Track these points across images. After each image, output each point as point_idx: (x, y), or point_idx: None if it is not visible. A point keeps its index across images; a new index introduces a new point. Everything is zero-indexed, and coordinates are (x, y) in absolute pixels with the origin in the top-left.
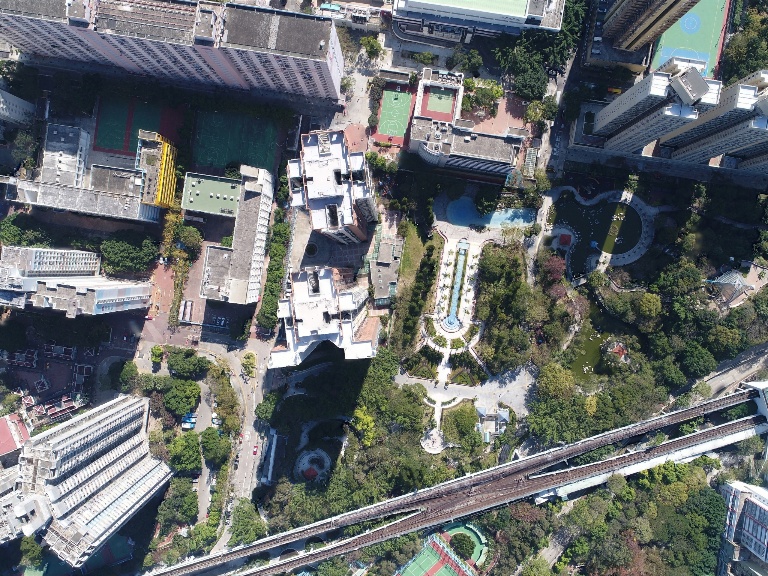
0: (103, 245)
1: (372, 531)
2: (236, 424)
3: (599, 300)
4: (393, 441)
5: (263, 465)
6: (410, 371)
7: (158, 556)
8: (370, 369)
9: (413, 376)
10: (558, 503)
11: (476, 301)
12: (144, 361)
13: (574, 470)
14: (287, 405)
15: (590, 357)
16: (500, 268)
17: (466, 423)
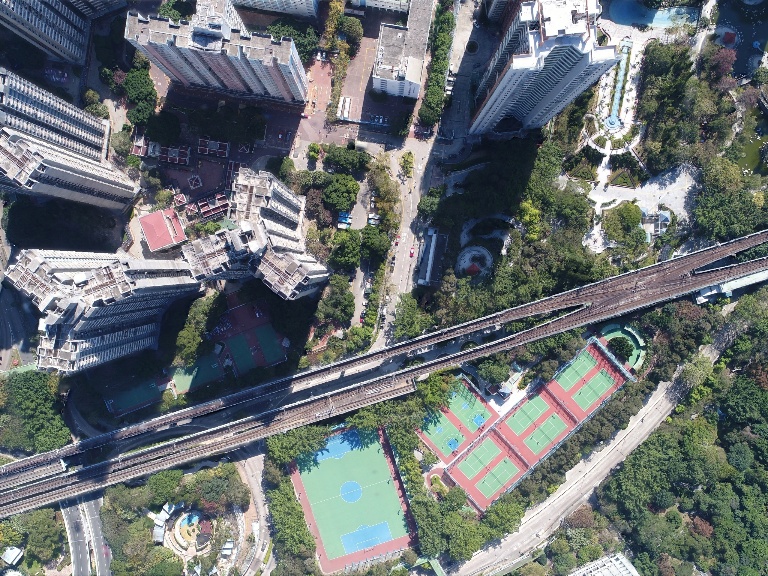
0: (266, 31)
1: (537, 326)
2: (396, 222)
3: (761, 101)
4: (558, 236)
5: (419, 268)
6: (570, 172)
7: (313, 358)
8: (537, 162)
9: (573, 177)
10: (720, 301)
11: (638, 101)
12: (299, 161)
13: (739, 266)
14: (451, 199)
15: (750, 160)
16: (671, 58)
17: (632, 217)
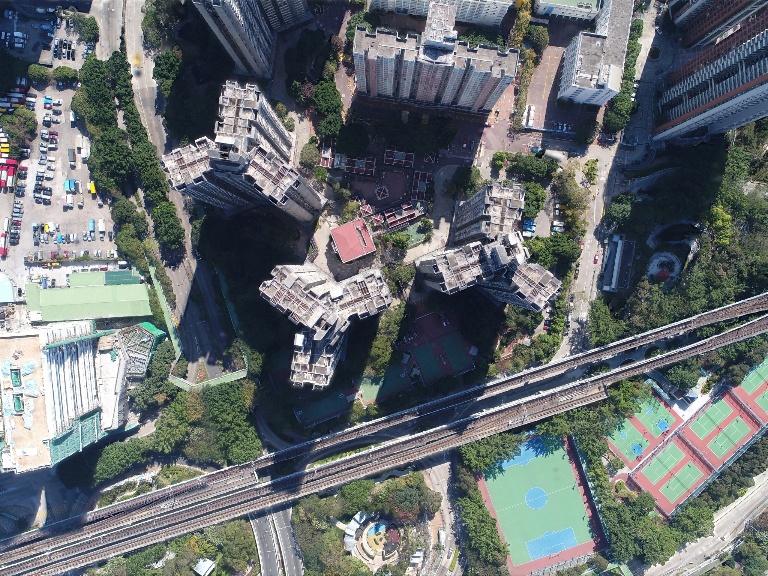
0: None
1: (728, 331)
2: (583, 229)
3: None
4: (747, 241)
5: (603, 274)
6: (754, 176)
7: (501, 366)
8: (727, 167)
9: (756, 181)
10: None
11: None
12: (482, 170)
13: None
14: (641, 206)
15: None
16: None
17: None
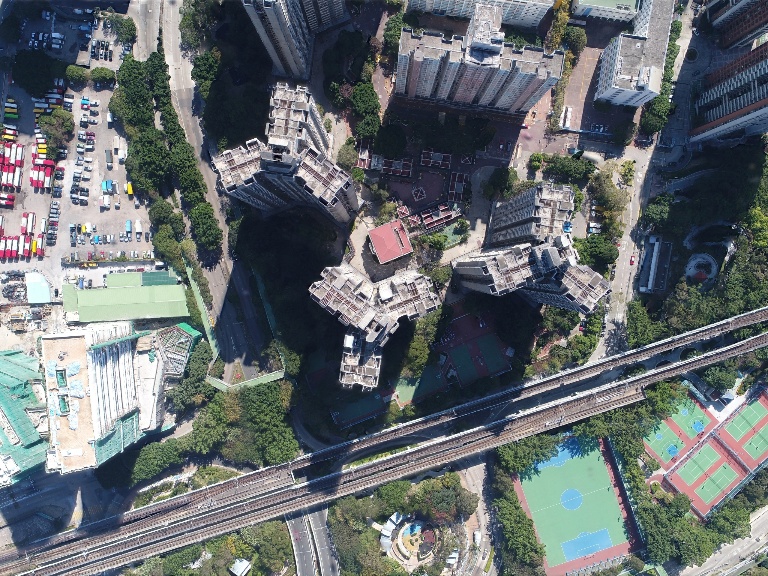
0: None
1: (766, 332)
2: None
3: None
4: None
5: (639, 275)
6: None
7: (538, 367)
8: (765, 168)
9: None
10: None
11: None
12: (518, 171)
13: None
14: (678, 207)
15: None
16: None
17: None
